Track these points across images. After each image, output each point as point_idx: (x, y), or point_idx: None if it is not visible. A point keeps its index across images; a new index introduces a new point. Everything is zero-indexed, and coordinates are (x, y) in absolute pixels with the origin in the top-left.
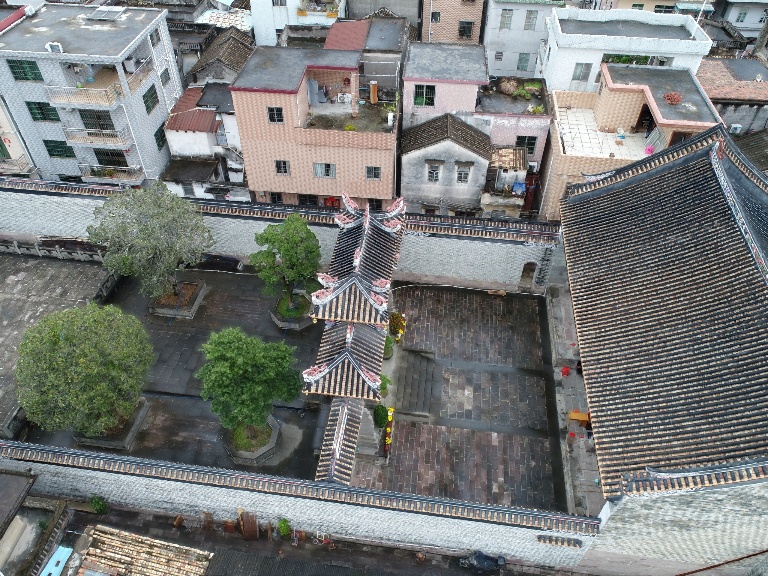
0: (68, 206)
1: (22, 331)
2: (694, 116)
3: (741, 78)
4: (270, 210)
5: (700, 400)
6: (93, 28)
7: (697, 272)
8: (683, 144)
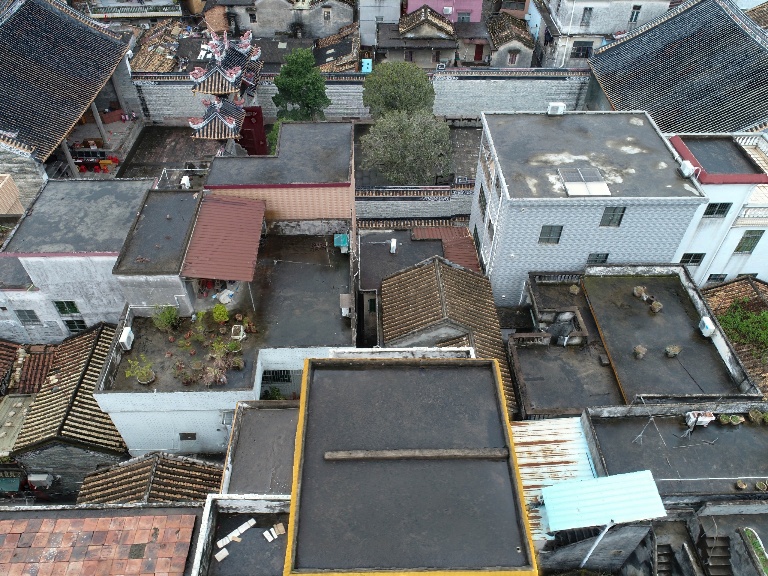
0: None
1: None
2: None
3: None
4: None
5: None
6: (568, 155)
7: (7, 69)
8: None
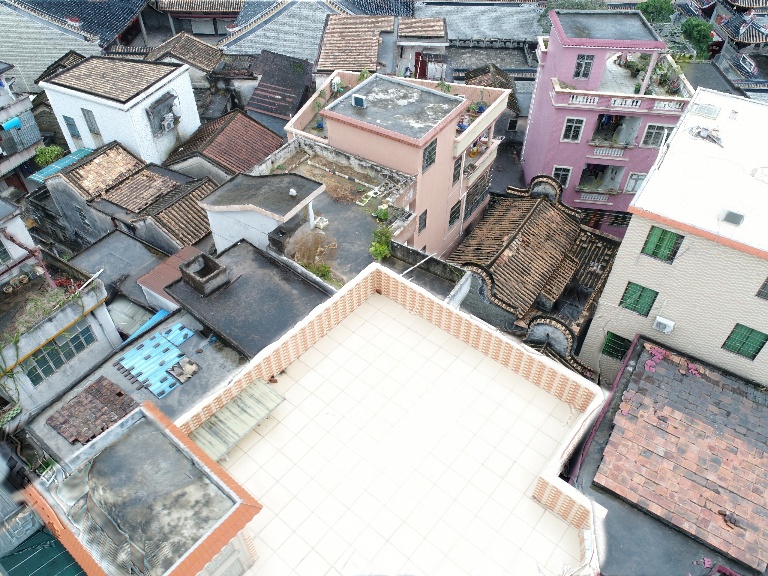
0: (489, 13)
1: None
2: None
3: None
4: (618, 5)
5: None
6: None
7: None
8: None
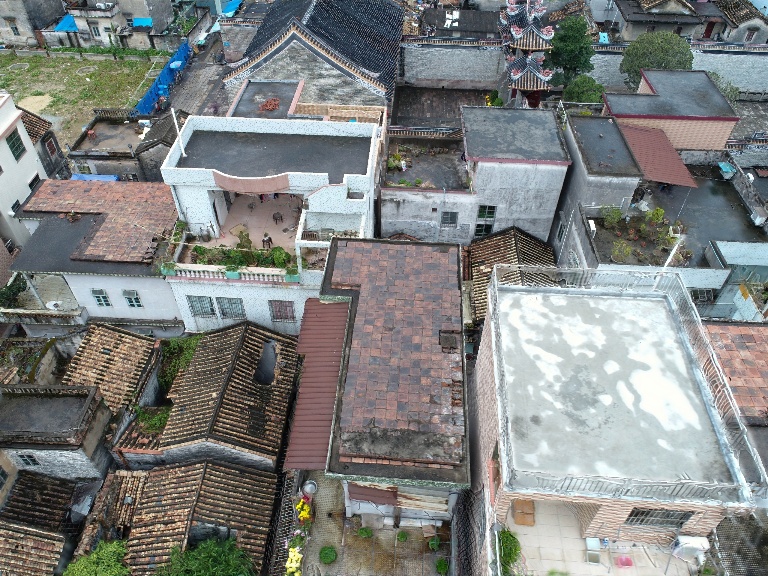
0: None
1: (743, 134)
2: (265, 89)
3: (91, 223)
4: None
5: (364, 2)
6: None
7: None
8: (315, 35)
